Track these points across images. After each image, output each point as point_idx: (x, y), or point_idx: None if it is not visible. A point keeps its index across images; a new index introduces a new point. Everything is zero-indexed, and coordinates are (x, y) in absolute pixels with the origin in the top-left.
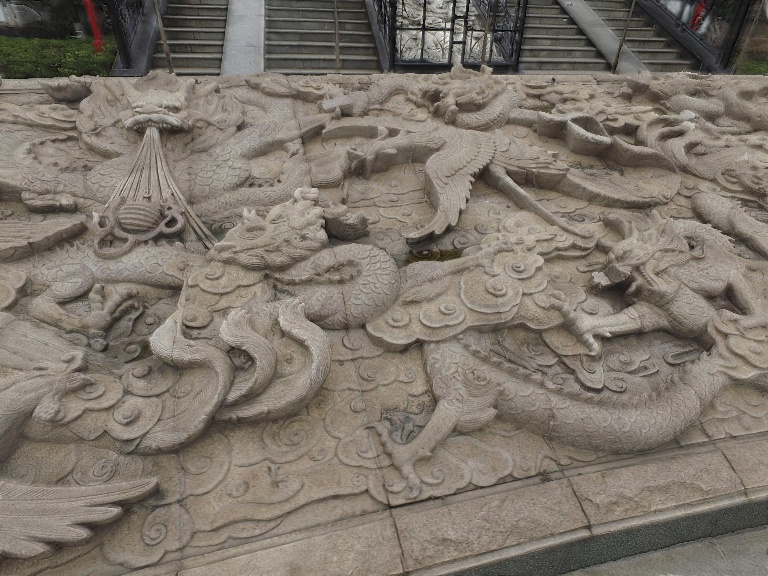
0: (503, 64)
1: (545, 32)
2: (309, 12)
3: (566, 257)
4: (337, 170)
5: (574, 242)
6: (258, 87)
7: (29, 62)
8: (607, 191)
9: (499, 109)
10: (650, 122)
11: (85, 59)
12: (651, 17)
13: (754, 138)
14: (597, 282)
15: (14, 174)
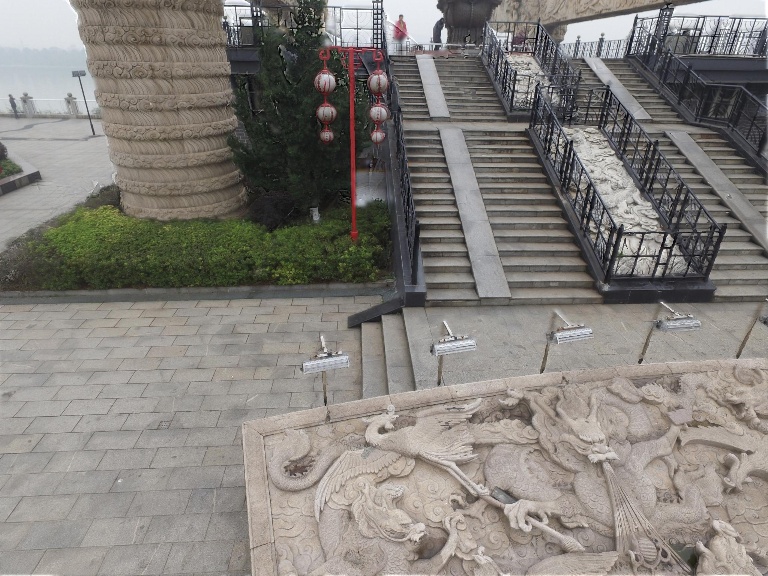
0: (696, 276)
1: None
2: (518, 212)
3: None
4: (720, 496)
5: None
6: (617, 394)
7: (320, 259)
8: None
9: None
10: None
11: (358, 255)
12: None
13: None
14: None
15: (556, 506)
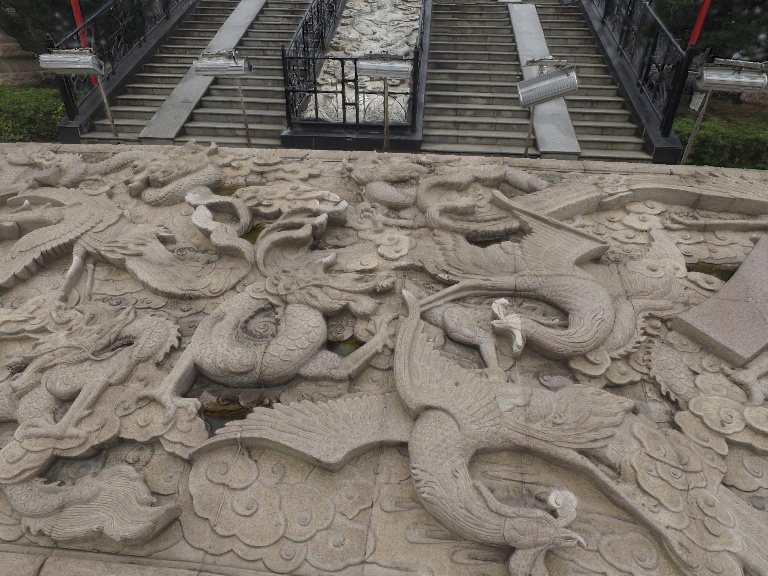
0: (400, 125)
1: (488, 90)
2: (262, 70)
3: (35, 339)
4: None
5: (46, 326)
6: None
7: (34, 110)
8: (156, 279)
9: (169, 188)
10: (292, 211)
11: None
12: (617, 75)
13: (388, 236)
14: (7, 368)
15: None
